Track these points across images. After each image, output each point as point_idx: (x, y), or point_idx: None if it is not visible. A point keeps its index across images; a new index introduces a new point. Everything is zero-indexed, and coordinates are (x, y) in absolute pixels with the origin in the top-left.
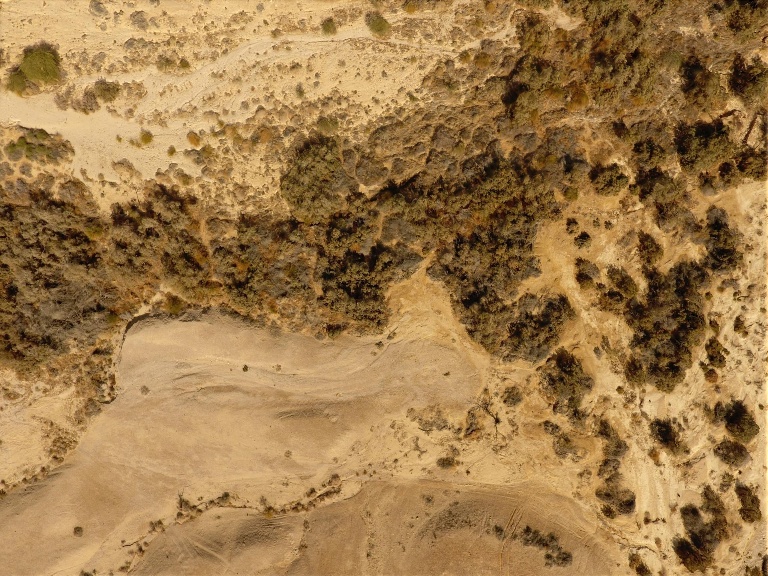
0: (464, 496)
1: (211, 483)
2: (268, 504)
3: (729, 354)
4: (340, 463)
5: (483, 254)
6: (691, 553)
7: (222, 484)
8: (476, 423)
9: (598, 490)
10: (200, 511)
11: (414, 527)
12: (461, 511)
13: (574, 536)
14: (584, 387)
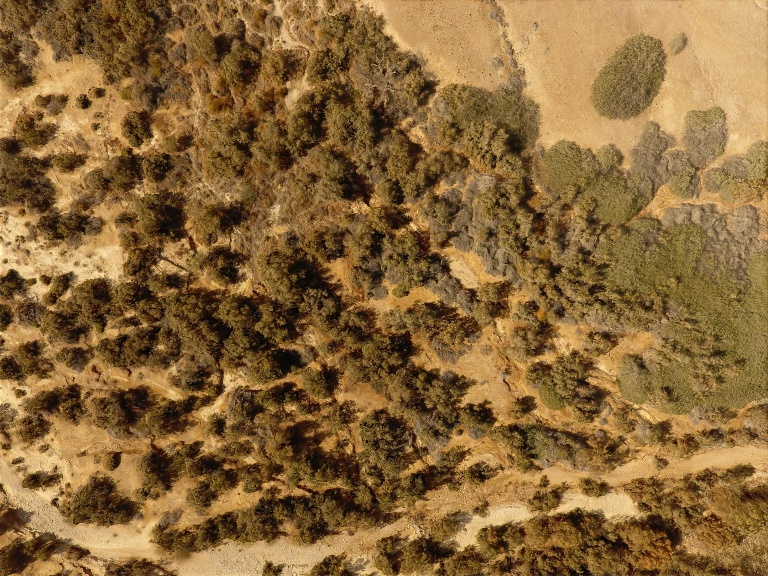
0: None
1: None
2: None
3: None
4: None
5: (71, 2)
6: None
7: None
8: None
9: None
10: None
11: None
12: None
13: None
14: None
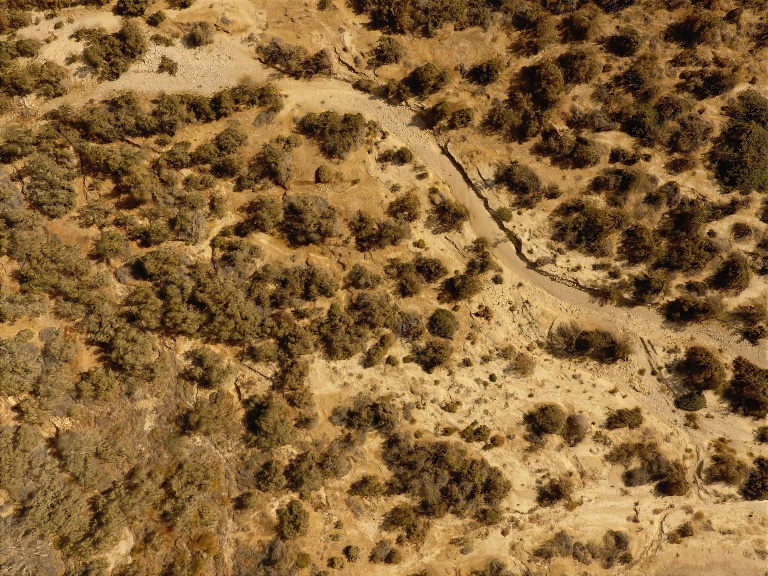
0: None
1: None
2: None
3: (477, 421)
4: None
5: None
6: (670, 488)
7: None
8: None
9: (603, 567)
10: None
11: None
12: None
13: None
14: (500, 574)
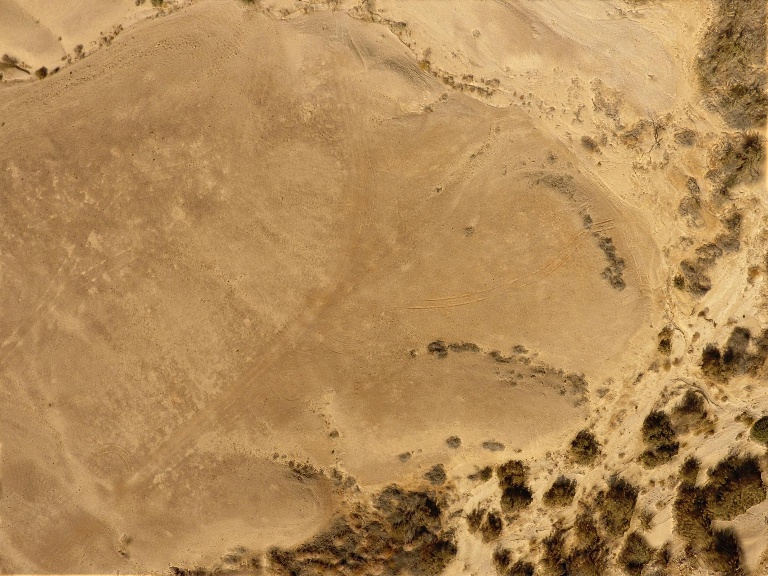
0: (582, 177)
1: (399, 6)
2: (428, 58)
3: None
4: (509, 74)
5: (767, 2)
6: None
7: (406, 14)
8: (639, 132)
9: (686, 260)
10: (373, 20)
11: (526, 165)
12: (571, 184)
13: (638, 277)
14: (749, 173)
